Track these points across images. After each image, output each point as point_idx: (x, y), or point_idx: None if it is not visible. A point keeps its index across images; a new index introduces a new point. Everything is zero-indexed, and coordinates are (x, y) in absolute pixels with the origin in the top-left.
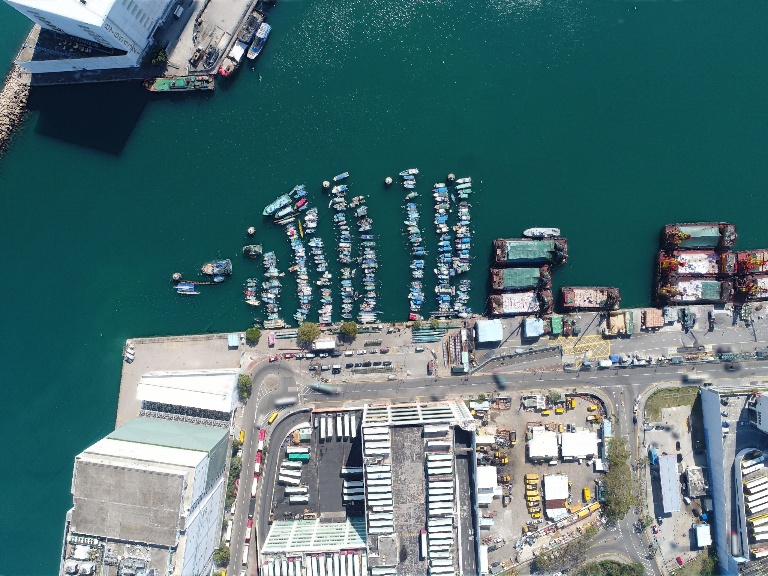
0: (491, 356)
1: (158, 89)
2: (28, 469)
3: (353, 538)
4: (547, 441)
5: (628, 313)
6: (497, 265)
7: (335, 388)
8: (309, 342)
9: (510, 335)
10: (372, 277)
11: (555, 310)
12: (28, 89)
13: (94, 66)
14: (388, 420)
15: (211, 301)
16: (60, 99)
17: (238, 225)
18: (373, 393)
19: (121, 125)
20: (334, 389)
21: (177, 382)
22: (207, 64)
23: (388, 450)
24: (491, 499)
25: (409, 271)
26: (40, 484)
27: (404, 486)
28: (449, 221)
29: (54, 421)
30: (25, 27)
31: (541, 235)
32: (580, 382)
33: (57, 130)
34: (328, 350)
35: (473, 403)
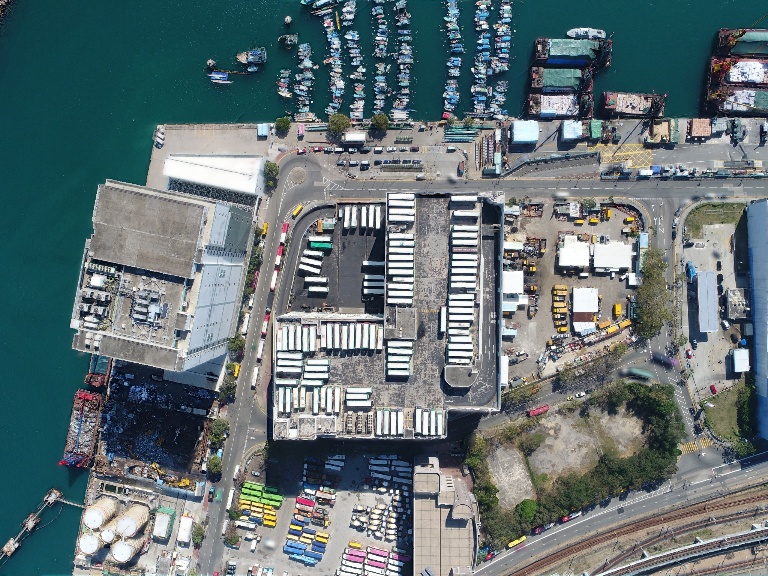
0: (525, 160)
1: None
2: (53, 251)
3: (370, 317)
4: (579, 250)
5: (673, 120)
6: (537, 66)
7: (362, 185)
8: (339, 136)
9: (546, 139)
10: (407, 73)
11: (595, 117)
12: None
13: None
14: None
15: (243, 92)
16: None
17: (275, 15)
18: None
19: None
20: (361, 186)
21: (204, 162)
22: None
23: (412, 217)
24: (516, 307)
25: (445, 69)
26: (64, 267)
27: (426, 259)
28: (490, 19)
29: (82, 205)
30: None
31: (585, 35)
32: (617, 192)
33: None
34: (357, 145)
35: None
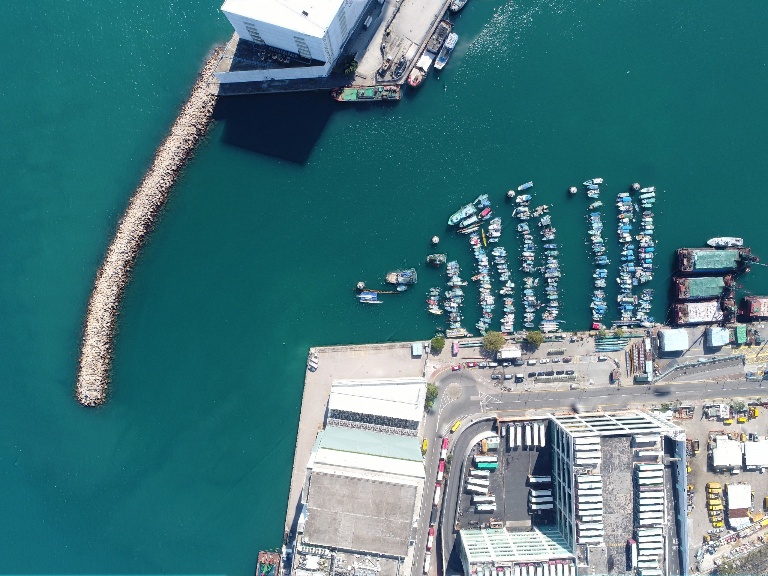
0: (674, 365)
1: (346, 99)
2: (209, 477)
3: (555, 548)
4: (731, 450)
5: None
6: (680, 274)
7: (517, 397)
8: (492, 351)
9: (693, 344)
10: (555, 286)
11: (737, 319)
12: (215, 99)
13: (284, 76)
14: (593, 430)
15: (393, 310)
16: (247, 109)
17: (421, 234)
18: (555, 402)
19: (306, 135)
20: (516, 398)
21: (367, 391)
22: (396, 74)
23: (600, 460)
24: None
25: (591, 280)
26: (220, 492)
27: (612, 496)
28: (632, 230)
29: (235, 429)
30: (211, 37)
31: (725, 244)
32: (762, 391)
33: (242, 139)
34: (511, 359)
35: (657, 412)
